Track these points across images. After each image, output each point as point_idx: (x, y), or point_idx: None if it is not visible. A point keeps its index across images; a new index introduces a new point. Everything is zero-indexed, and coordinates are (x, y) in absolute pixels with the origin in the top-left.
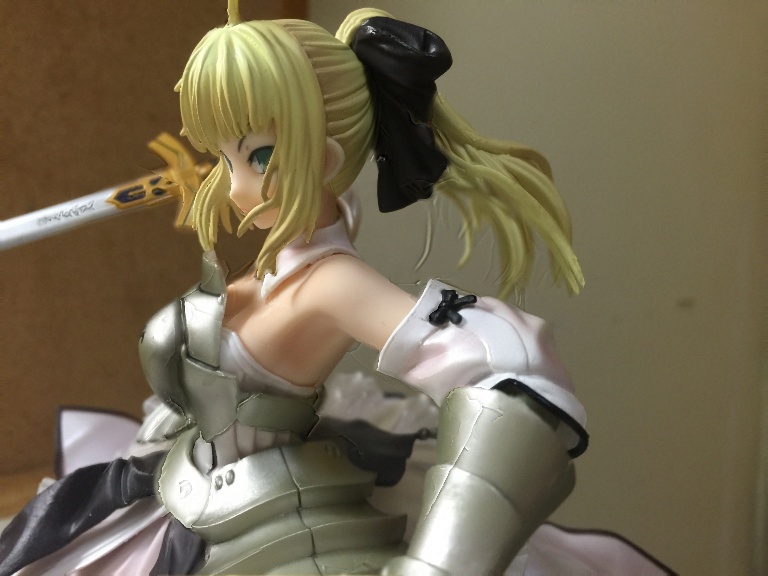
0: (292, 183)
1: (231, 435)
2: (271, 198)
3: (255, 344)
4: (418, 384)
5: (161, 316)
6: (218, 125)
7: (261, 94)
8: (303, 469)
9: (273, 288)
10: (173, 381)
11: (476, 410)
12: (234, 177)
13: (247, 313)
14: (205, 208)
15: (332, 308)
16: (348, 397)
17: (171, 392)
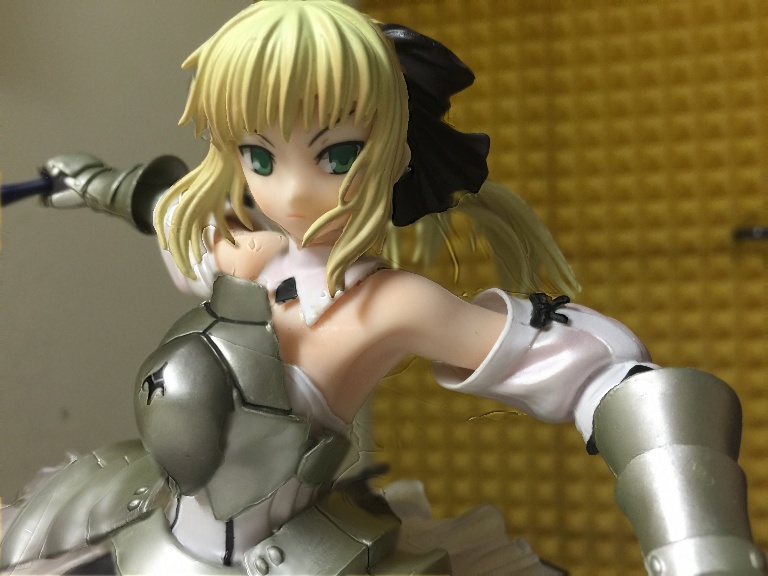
0: (379, 184)
1: (267, 502)
2: (351, 201)
3: (322, 377)
4: (523, 391)
5: (173, 359)
6: (306, 111)
7: (378, 79)
8: (350, 524)
9: (324, 310)
10: (217, 441)
11: (637, 396)
12: (290, 177)
13: (292, 343)
14: (185, 222)
15: (423, 323)
16: (391, 429)
17: (209, 457)
